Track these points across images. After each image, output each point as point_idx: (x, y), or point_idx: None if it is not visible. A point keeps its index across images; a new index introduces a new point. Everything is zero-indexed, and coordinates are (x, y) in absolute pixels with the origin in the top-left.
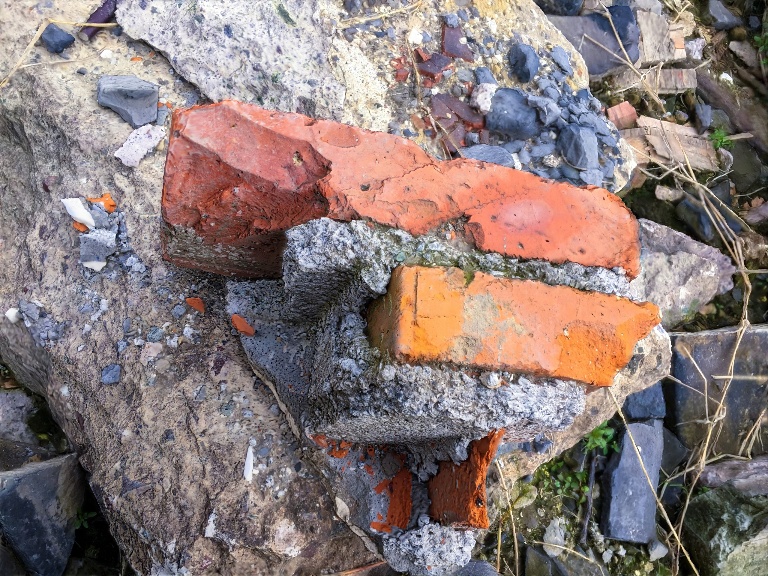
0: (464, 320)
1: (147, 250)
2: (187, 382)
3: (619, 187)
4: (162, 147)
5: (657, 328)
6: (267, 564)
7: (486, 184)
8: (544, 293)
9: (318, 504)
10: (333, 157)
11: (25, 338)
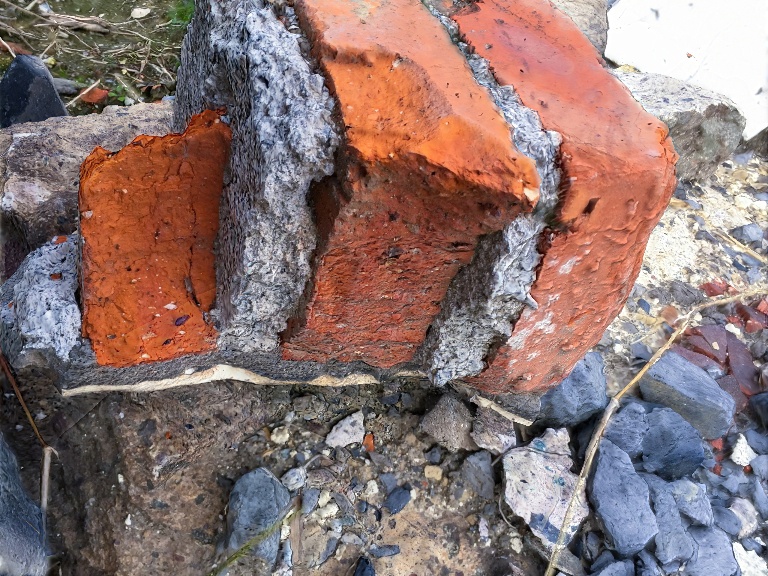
0: None
1: None
2: None
3: None
4: None
5: None
6: None
7: (537, 12)
8: (434, 34)
9: None
10: None
11: None
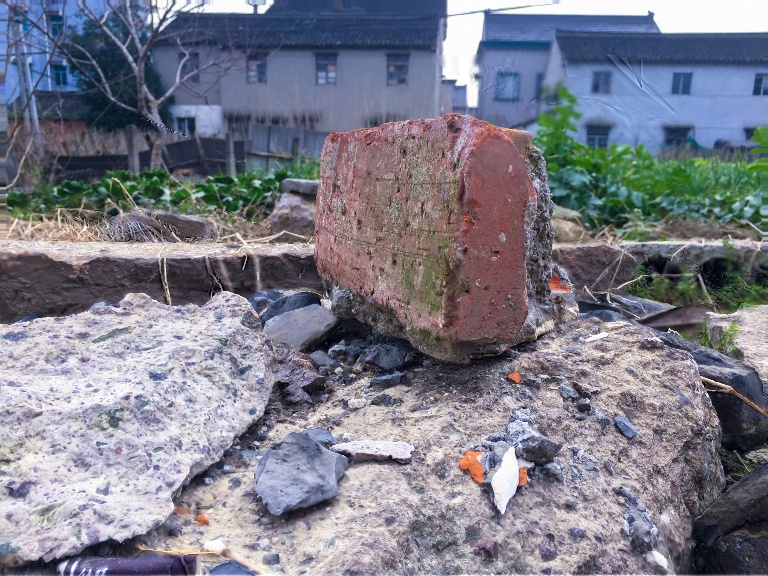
0: None
1: (496, 418)
2: None
3: None
4: None
5: None
6: None
7: None
8: None
9: None
10: None
11: None
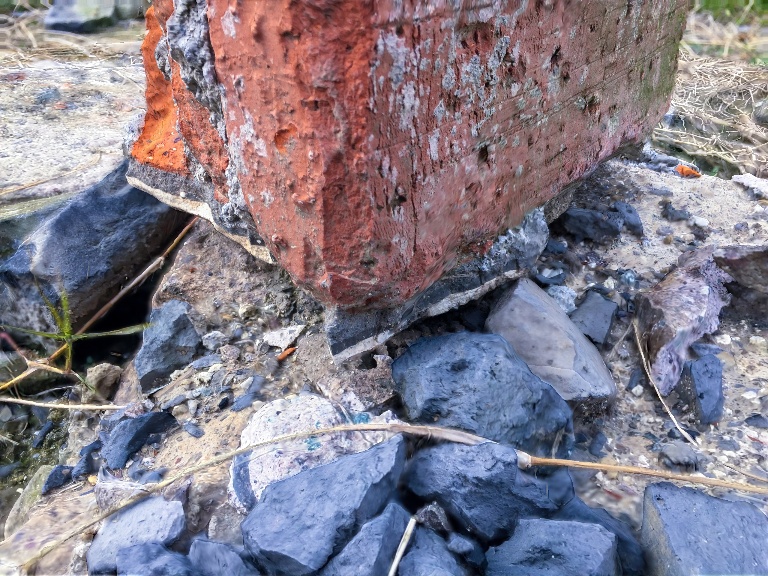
0: None
1: None
2: None
3: None
4: (763, 200)
5: None
6: None
7: None
8: None
9: None
10: None
11: None
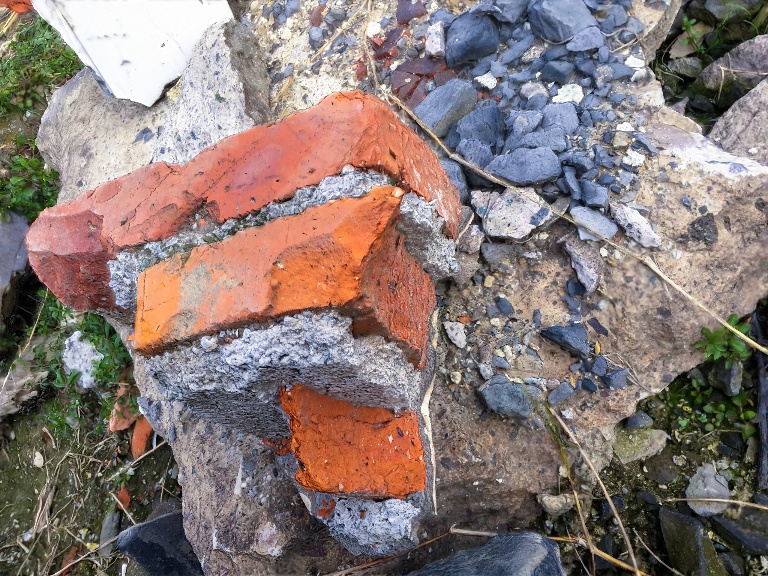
0: (181, 298)
1: None
2: (200, 424)
3: (650, 24)
4: None
5: (729, 170)
6: (264, 567)
7: (218, 161)
8: (253, 237)
9: (293, 503)
10: (104, 211)
11: (155, 424)
